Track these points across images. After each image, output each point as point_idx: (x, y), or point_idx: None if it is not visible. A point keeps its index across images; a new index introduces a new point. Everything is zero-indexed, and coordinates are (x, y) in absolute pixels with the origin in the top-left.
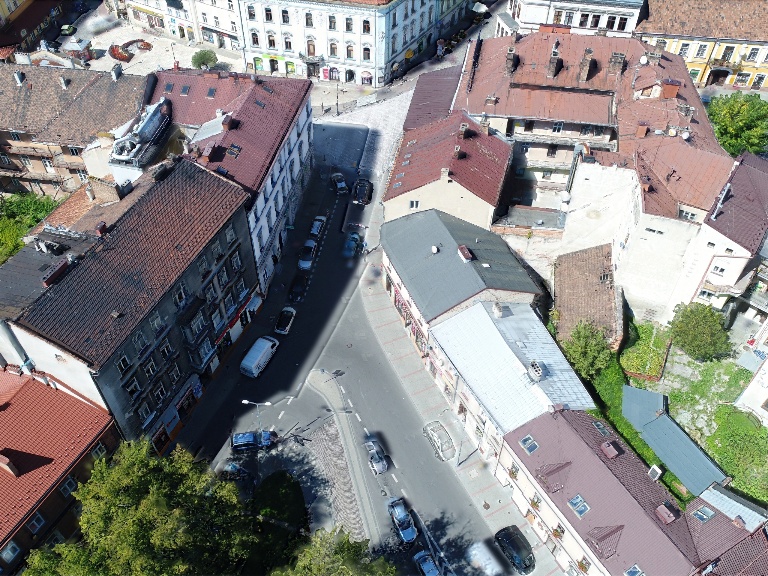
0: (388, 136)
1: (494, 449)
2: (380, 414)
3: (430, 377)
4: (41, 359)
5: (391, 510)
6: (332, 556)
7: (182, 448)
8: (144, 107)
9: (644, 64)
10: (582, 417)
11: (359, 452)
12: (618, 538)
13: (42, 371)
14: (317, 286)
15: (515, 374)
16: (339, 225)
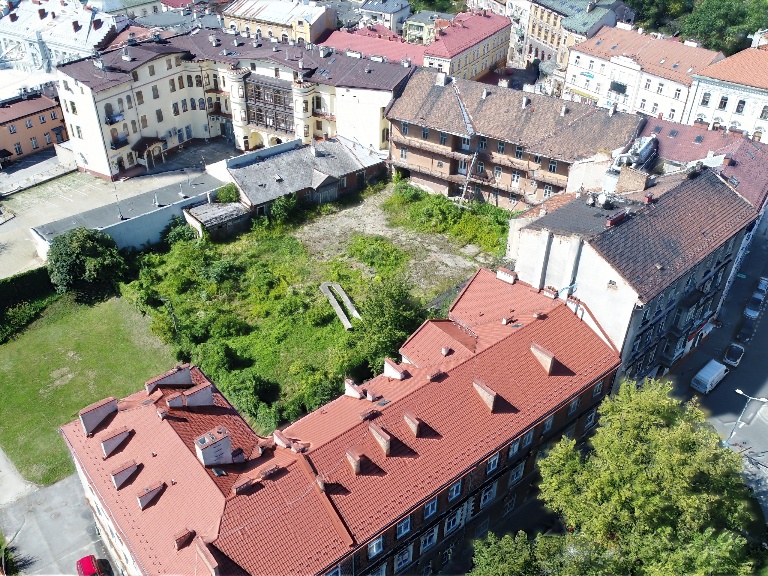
0: None
1: None
2: None
3: None
4: (588, 284)
5: None
6: None
7: None
8: (636, 139)
9: None
10: None
11: None
12: None
13: (578, 299)
14: (764, 336)
15: None
16: None
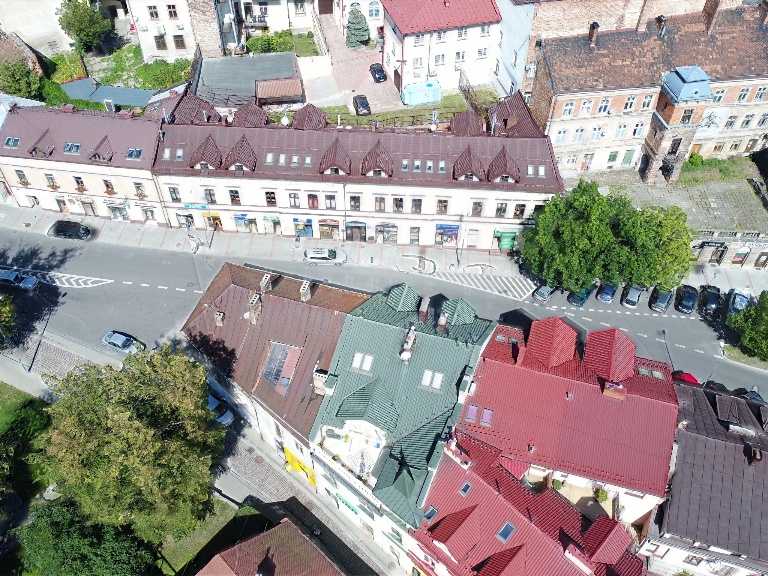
0: None
1: None
2: None
3: None
4: None
5: None
6: None
7: None
8: None
9: None
10: None
11: None
12: (108, 144)
13: None
14: None
15: None
16: None
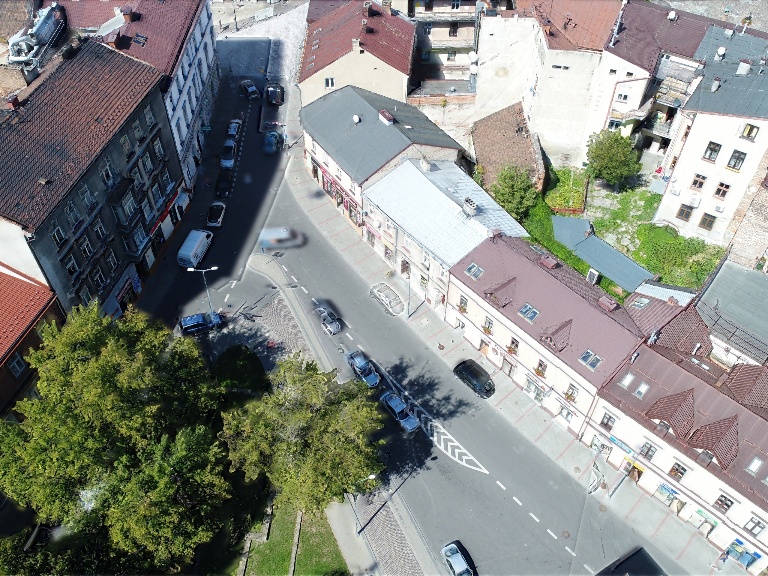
0: (291, 44)
1: (441, 292)
2: (325, 284)
3: (369, 247)
4: None
5: (351, 361)
6: (304, 373)
7: (134, 308)
8: (35, 13)
9: None
10: (519, 241)
11: (311, 319)
12: (569, 331)
13: None
14: (243, 182)
15: (451, 214)
16: (256, 126)
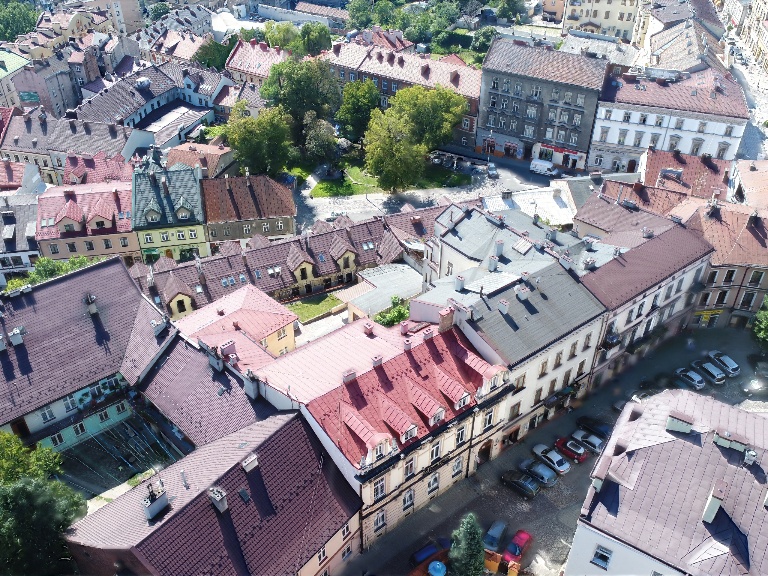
0: None
1: None
2: None
3: None
4: None
5: None
6: None
7: None
8: None
9: None
10: None
11: None
12: None
13: None
14: None
15: None
16: None
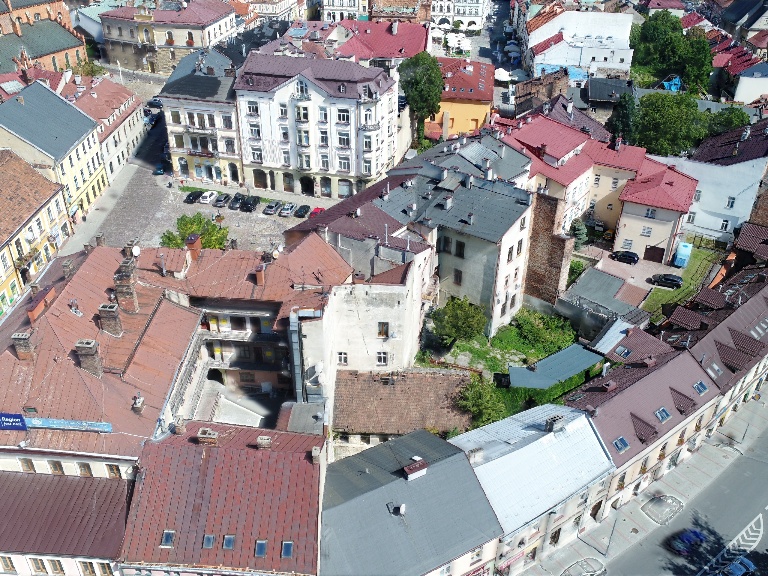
0: None
1: None
2: None
3: None
4: None
5: None
6: None
7: None
8: None
9: (138, 255)
10: None
11: None
12: None
13: None
14: None
15: (556, 445)
16: None
